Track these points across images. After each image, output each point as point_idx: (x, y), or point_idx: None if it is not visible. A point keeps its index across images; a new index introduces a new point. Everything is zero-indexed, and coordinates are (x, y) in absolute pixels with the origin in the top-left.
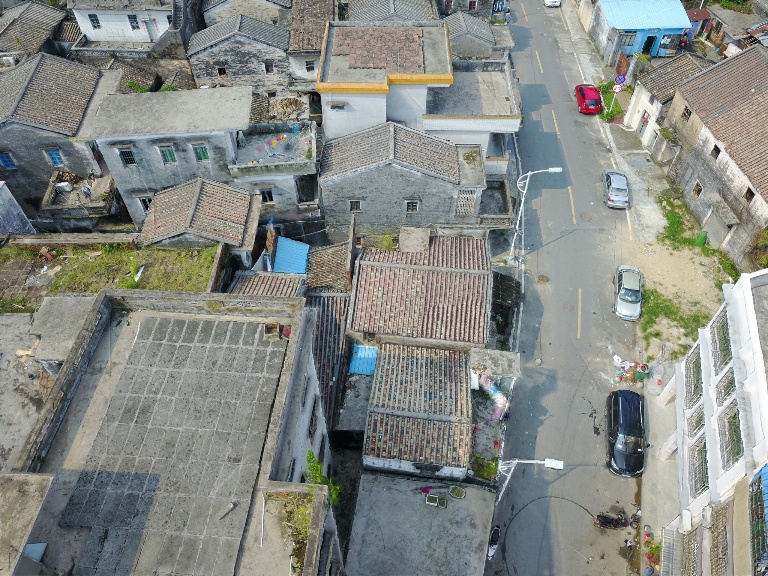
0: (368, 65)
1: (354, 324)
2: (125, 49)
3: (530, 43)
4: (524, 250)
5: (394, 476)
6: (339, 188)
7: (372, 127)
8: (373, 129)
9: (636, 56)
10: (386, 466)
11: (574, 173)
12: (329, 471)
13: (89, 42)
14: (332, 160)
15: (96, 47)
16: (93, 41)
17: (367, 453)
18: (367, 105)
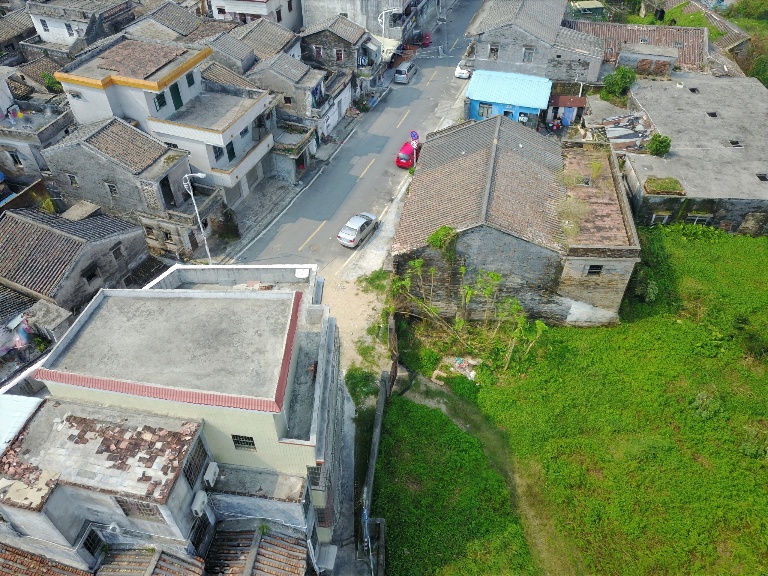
0: (110, 67)
1: None
2: (53, 48)
3: (410, 103)
4: (235, 260)
5: None
6: (56, 161)
7: (103, 118)
8: (103, 120)
9: (458, 122)
10: None
11: (340, 211)
12: None
13: (42, 41)
14: (64, 138)
15: (41, 45)
16: (45, 41)
17: None
18: (95, 98)
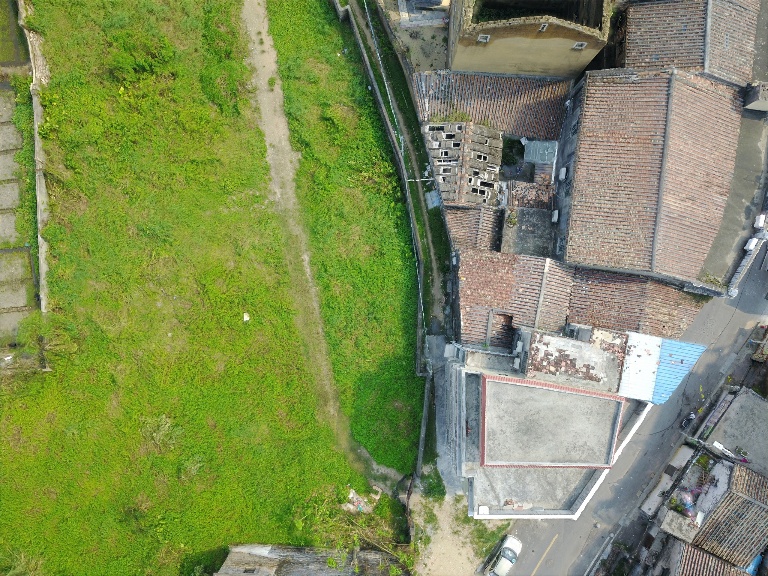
0: None
1: None
2: None
3: None
4: None
5: None
6: None
7: None
8: None
9: None
10: None
11: None
12: None
13: None
14: None
15: None
16: None
17: None
18: None
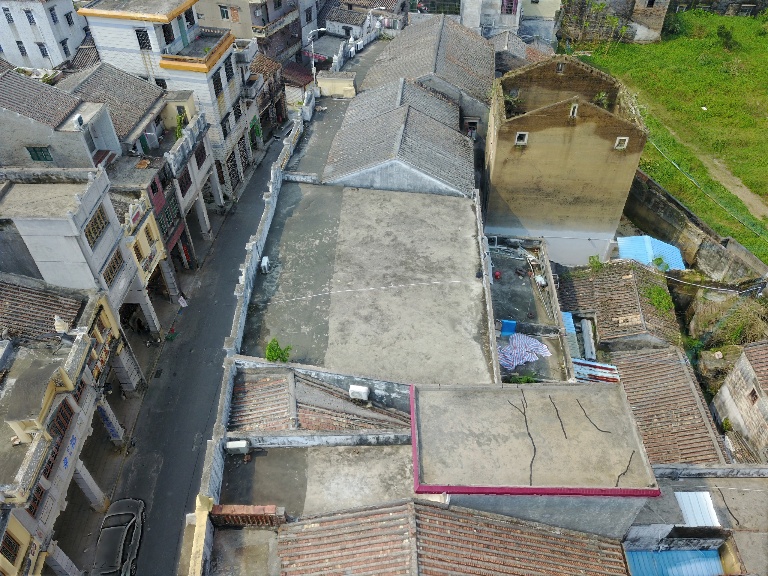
0: None
1: (345, 0)
2: None
3: None
4: None
5: (336, 37)
6: None
7: None
8: None
9: None
10: (334, 31)
11: None
12: (314, 36)
13: None
14: None
15: None
16: None
17: (327, 19)
18: None
